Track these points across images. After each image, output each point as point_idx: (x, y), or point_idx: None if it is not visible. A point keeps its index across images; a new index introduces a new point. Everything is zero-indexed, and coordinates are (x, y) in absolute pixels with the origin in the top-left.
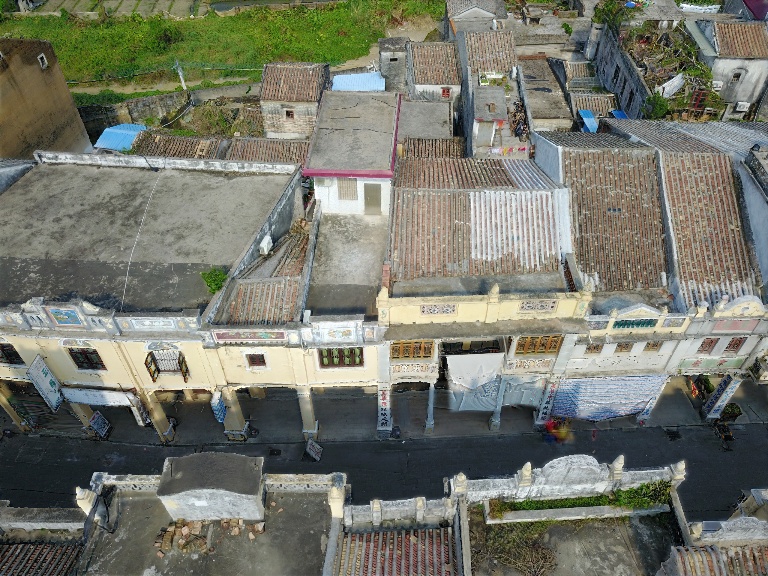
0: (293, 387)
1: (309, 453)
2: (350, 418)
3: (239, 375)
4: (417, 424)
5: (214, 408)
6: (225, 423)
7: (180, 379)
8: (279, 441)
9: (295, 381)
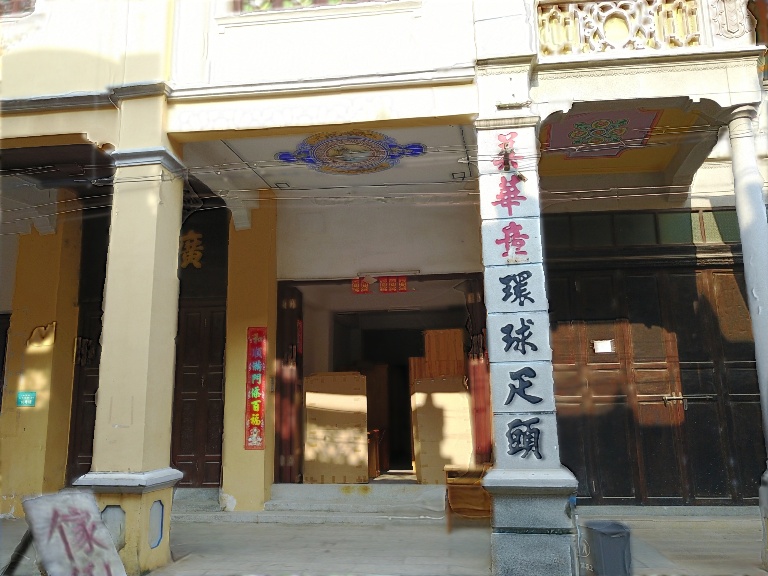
0: (109, 137)
1: (33, 536)
2: (348, 546)
3: None
4: (716, 562)
5: None
6: None
7: None
8: None
9: None
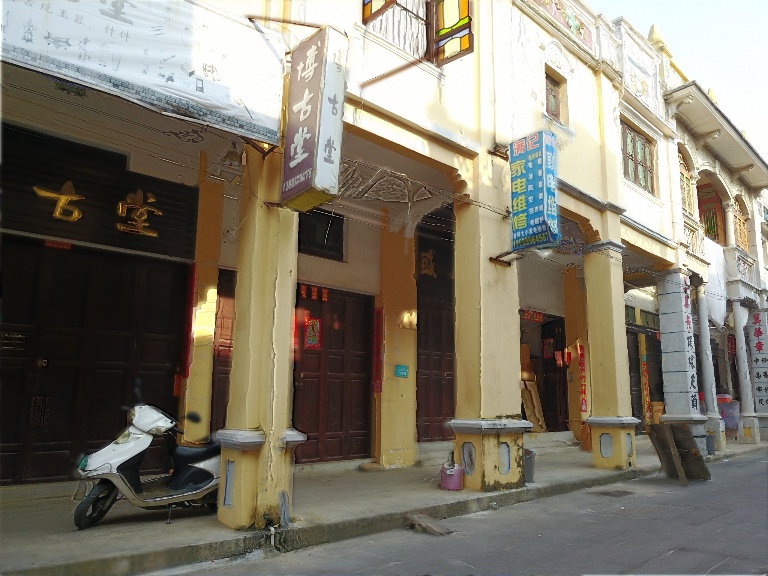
0: (596, 226)
1: (693, 440)
2: None
3: (530, 131)
4: None
5: (548, 160)
6: (485, 367)
7: (412, 88)
8: (587, 477)
9: (603, 197)
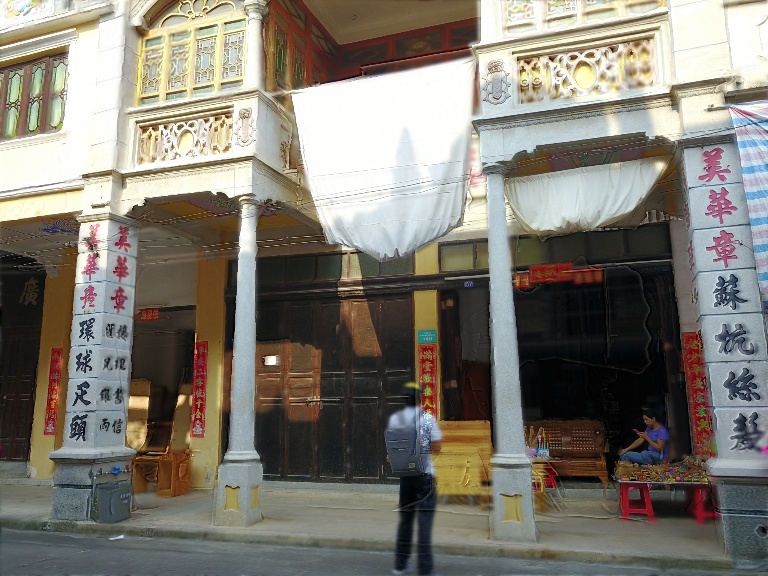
0: None
1: None
2: (41, 499)
3: None
4: None
5: None
6: None
7: None
8: None
9: None
